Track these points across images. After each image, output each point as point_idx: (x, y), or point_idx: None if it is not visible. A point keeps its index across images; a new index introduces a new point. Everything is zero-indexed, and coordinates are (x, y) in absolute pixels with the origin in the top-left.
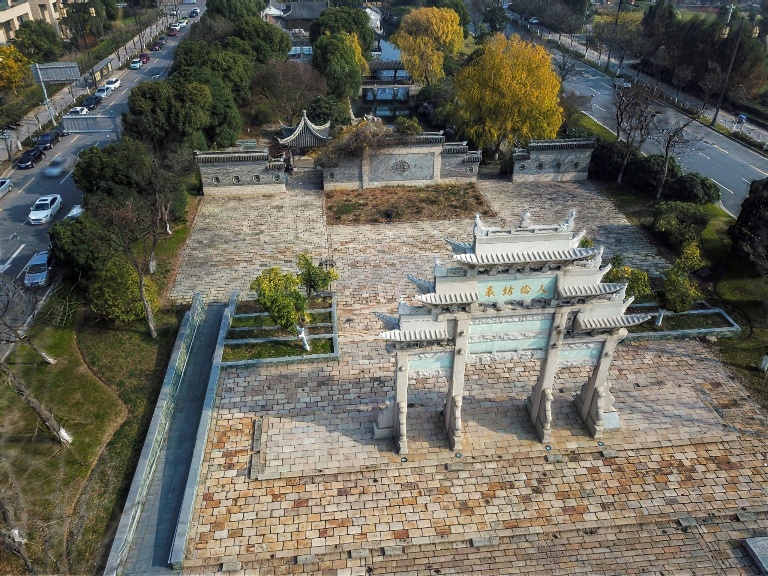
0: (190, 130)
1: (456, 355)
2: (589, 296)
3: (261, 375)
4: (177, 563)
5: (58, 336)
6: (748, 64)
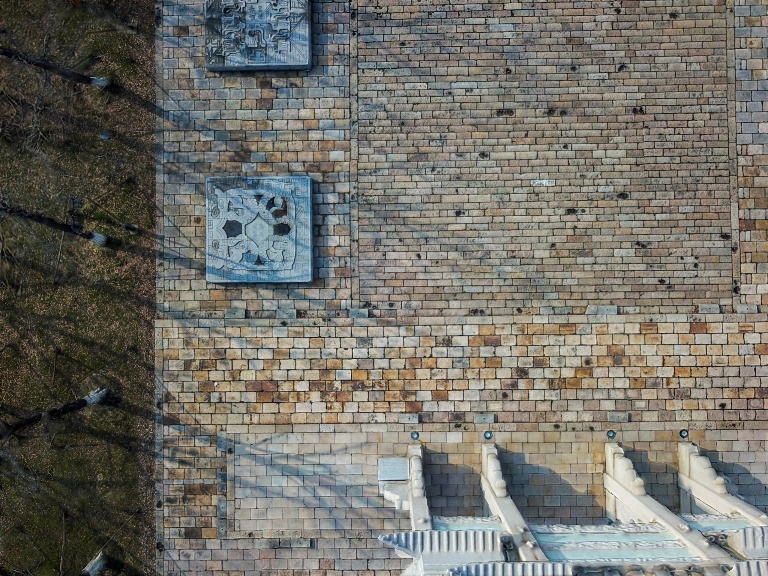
0: None
1: None
2: None
3: None
4: None
5: None
6: None
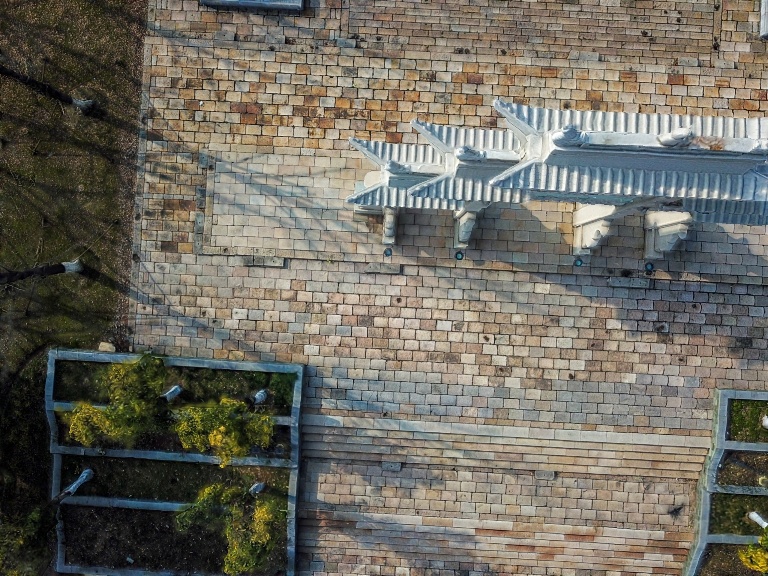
0: None
1: None
2: None
3: None
4: None
5: None
6: None
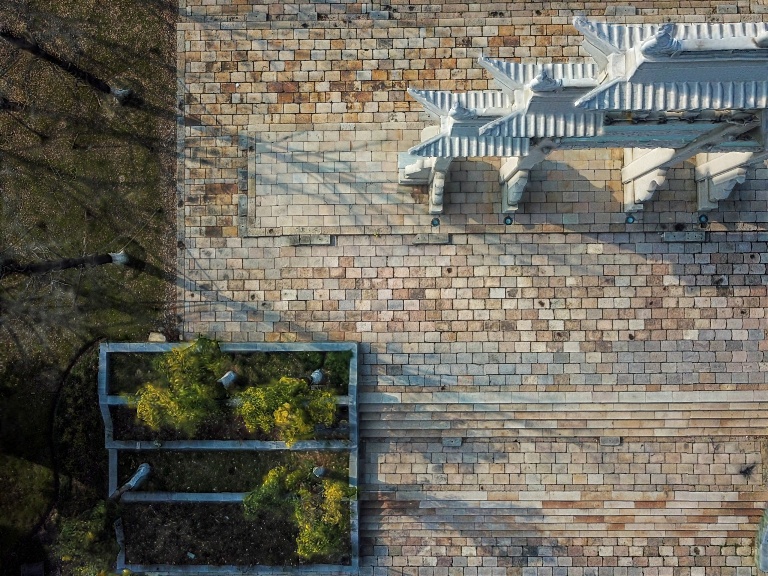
0: None
1: None
2: None
3: None
4: None
5: None
6: None
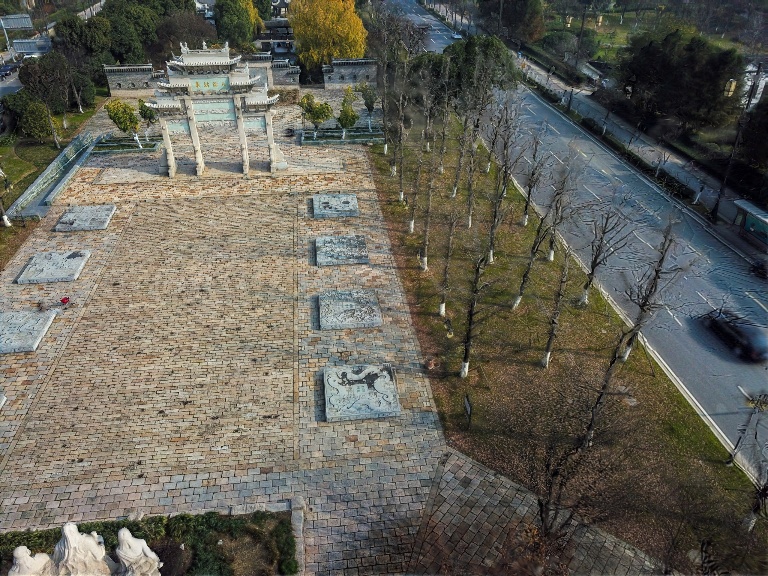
0: (96, 47)
1: (189, 121)
2: (246, 88)
3: (112, 157)
4: (48, 202)
5: (4, 149)
6: (527, 16)
